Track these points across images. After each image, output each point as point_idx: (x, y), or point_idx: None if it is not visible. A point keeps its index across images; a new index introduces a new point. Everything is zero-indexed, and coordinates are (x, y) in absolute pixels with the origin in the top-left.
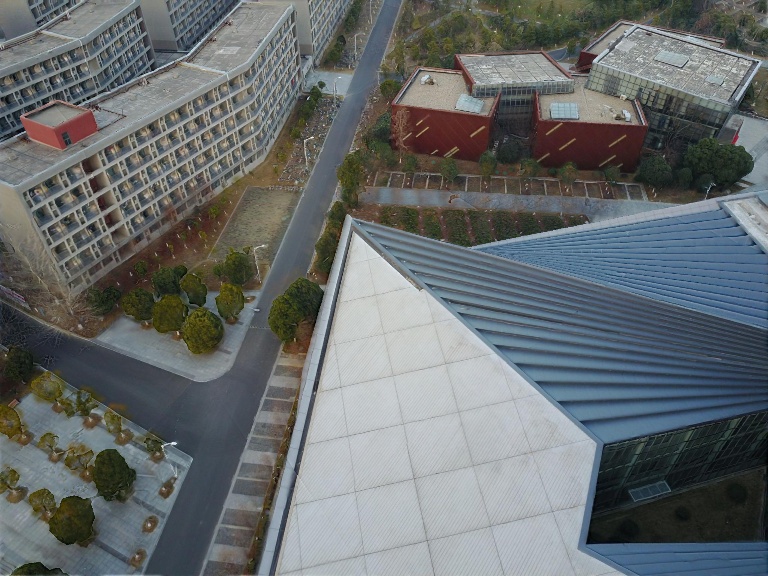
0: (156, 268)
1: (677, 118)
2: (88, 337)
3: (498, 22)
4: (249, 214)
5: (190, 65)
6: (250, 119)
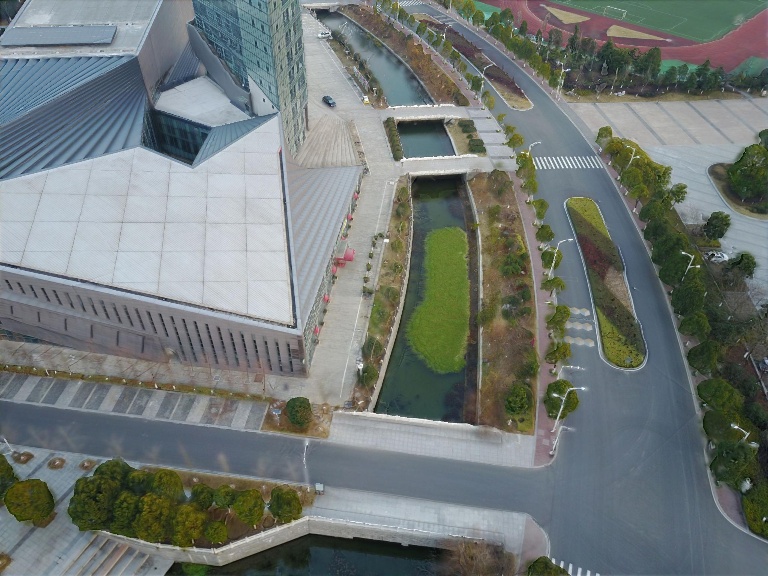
0: None
1: None
2: None
3: None
4: None
5: None
6: None
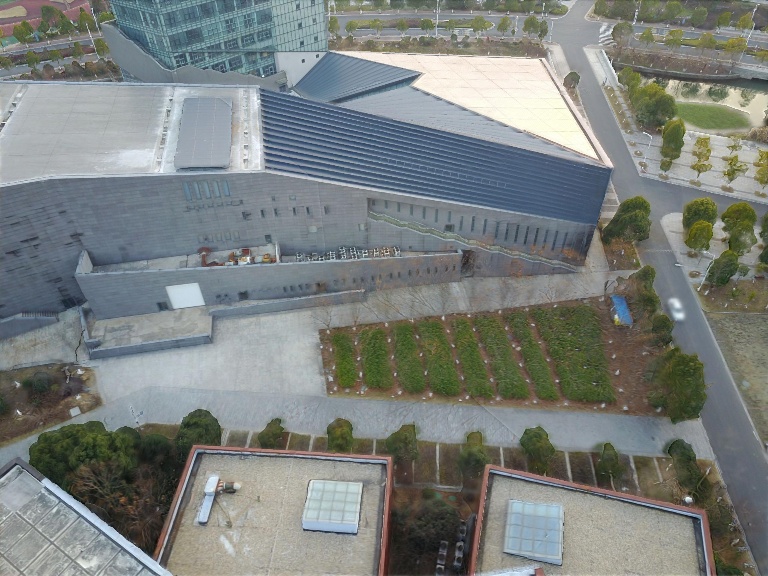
0: None
1: None
2: None
3: None
4: None
5: None
6: None
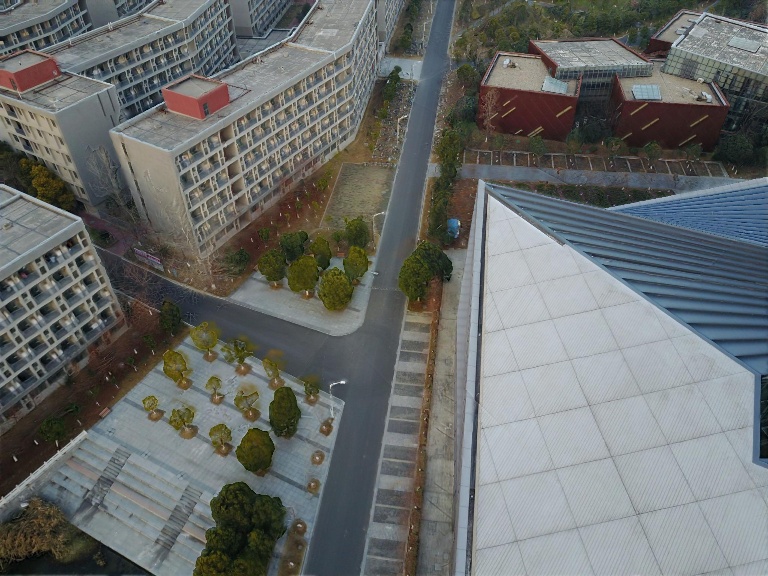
0: (274, 235)
1: (754, 100)
2: (222, 296)
3: (556, 12)
4: (350, 188)
5: (297, 45)
6: (347, 98)
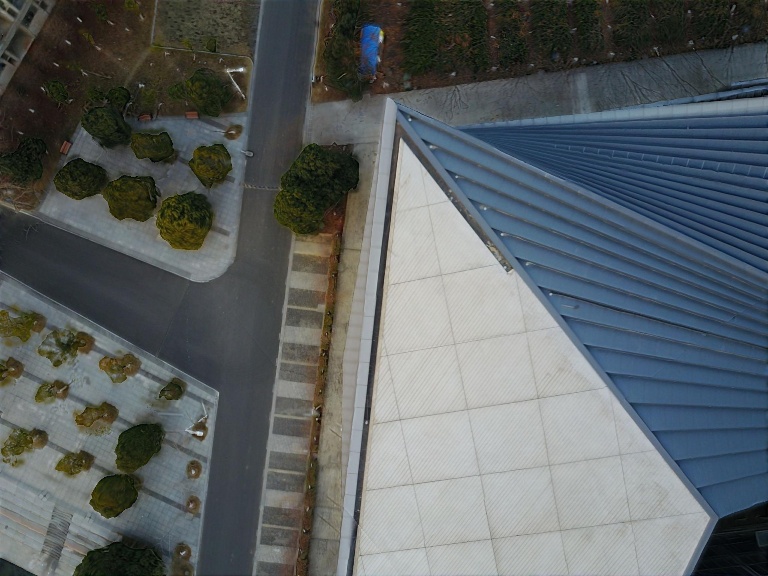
0: (78, 73)
1: None
2: (26, 209)
3: None
4: None
5: None
6: None
